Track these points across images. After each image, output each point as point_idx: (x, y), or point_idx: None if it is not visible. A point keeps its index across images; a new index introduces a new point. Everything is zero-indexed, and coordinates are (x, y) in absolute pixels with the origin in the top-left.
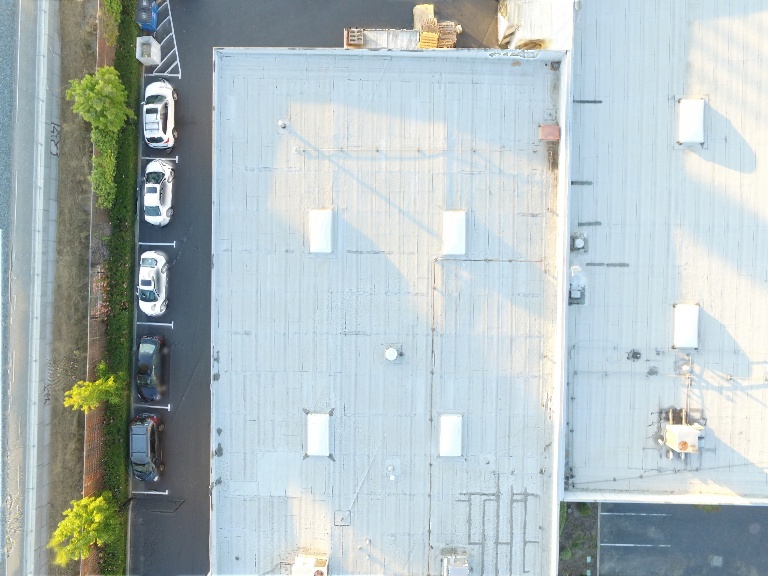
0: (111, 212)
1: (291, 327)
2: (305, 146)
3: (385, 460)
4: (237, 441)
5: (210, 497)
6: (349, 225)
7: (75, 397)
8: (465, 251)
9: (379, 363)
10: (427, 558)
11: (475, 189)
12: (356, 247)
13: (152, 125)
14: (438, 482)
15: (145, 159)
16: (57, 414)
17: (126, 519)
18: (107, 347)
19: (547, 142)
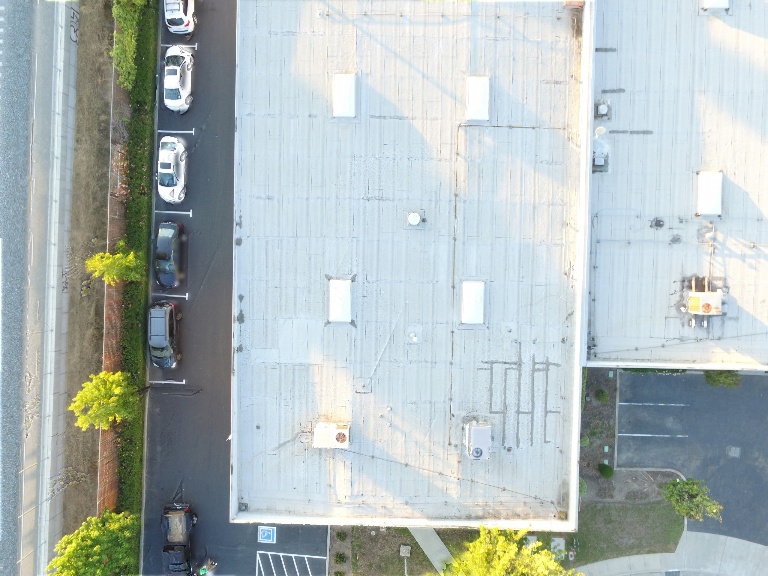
0: (131, 95)
1: (314, 192)
2: (329, 10)
3: (407, 327)
4: (259, 308)
5: (232, 362)
6: (372, 90)
7: (93, 287)
8: (488, 117)
9: (402, 229)
10: (448, 426)
11: (499, 55)
12: (379, 112)
13: (173, 6)
14: (460, 350)
15: (164, 46)
16: (75, 303)
17: (143, 407)
18: (126, 230)
19: (571, 9)
